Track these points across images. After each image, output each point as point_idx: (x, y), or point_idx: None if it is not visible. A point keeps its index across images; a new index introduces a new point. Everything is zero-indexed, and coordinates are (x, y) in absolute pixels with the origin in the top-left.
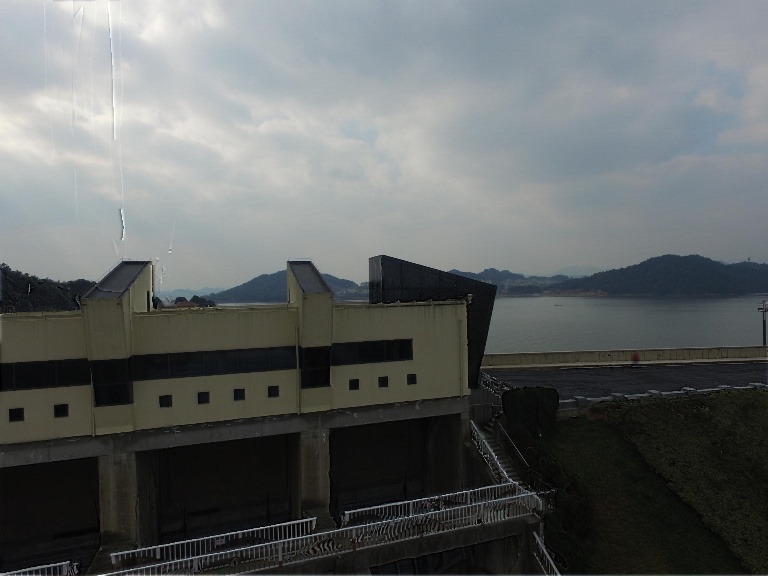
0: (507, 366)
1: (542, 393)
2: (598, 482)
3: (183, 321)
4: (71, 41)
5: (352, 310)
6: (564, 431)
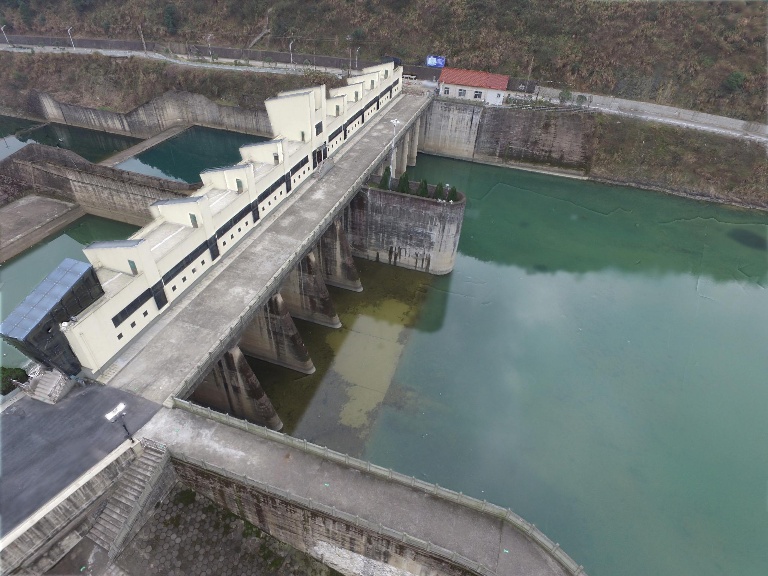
0: None
1: None
2: None
3: None
4: None
5: None
6: None
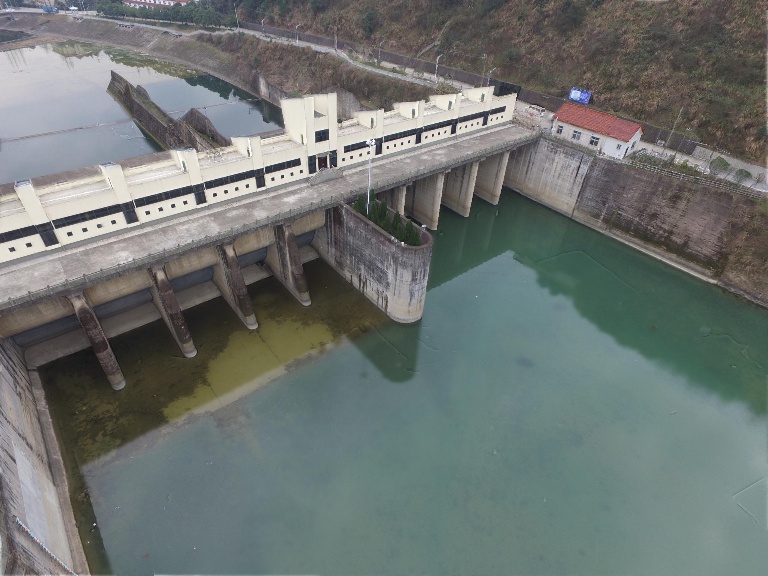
0: None
1: None
2: None
3: (86, 181)
4: None
5: (7, 197)
6: None
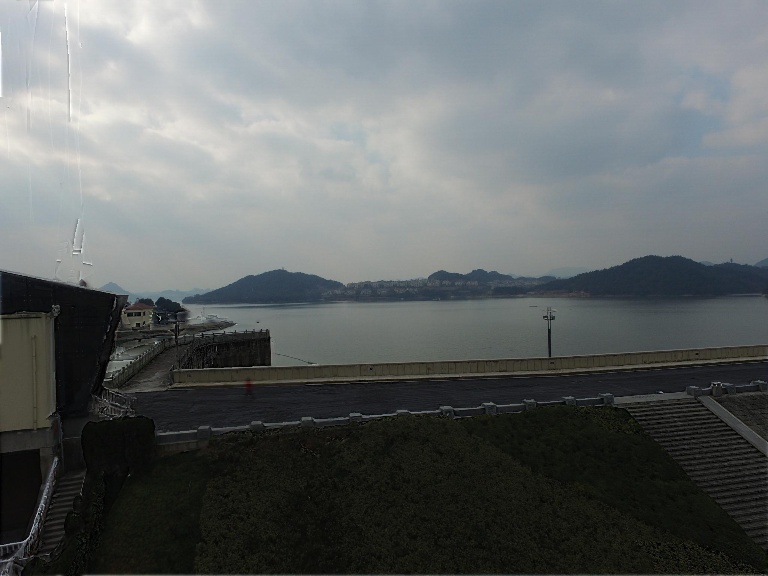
0: (249, 382)
1: (130, 425)
2: (136, 539)
3: None
4: (25, 37)
5: None
6: (156, 470)
